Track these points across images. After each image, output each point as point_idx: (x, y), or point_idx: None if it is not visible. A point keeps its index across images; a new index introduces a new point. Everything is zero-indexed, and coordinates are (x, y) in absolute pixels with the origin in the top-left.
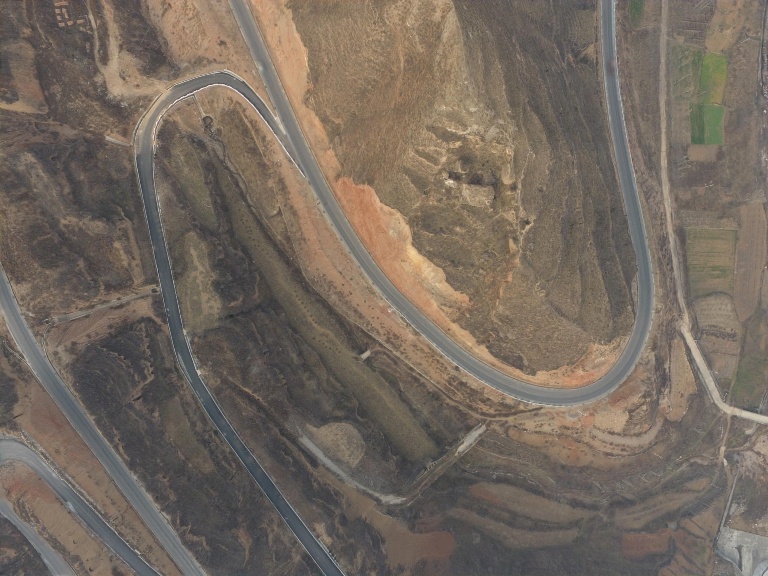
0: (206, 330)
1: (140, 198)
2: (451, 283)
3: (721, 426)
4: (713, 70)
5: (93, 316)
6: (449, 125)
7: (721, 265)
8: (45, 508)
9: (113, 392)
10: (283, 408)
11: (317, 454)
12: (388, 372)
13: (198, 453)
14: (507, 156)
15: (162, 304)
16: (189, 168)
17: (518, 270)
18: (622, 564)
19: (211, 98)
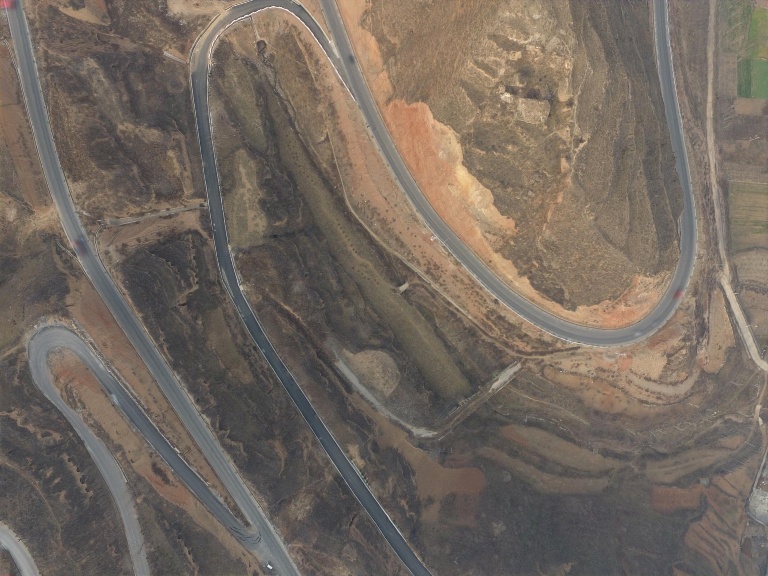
0: (250, 247)
1: (193, 114)
2: (498, 206)
3: (758, 383)
4: (762, 25)
5: (143, 223)
6: (511, 33)
7: (763, 220)
8: (91, 396)
9: (160, 294)
10: (321, 331)
11: (352, 380)
12: (425, 307)
13: (238, 364)
14: (565, 71)
15: (209, 219)
16: (241, 89)
17: (569, 189)
18: (652, 516)
19: (267, 21)
